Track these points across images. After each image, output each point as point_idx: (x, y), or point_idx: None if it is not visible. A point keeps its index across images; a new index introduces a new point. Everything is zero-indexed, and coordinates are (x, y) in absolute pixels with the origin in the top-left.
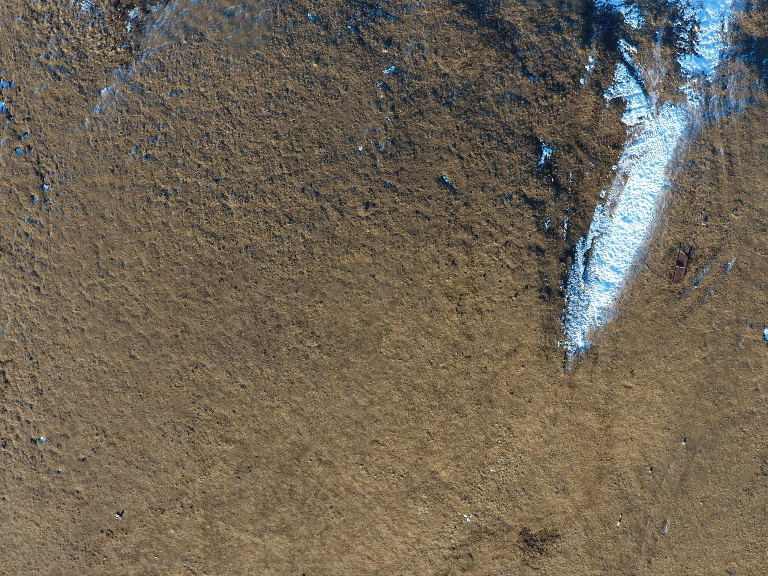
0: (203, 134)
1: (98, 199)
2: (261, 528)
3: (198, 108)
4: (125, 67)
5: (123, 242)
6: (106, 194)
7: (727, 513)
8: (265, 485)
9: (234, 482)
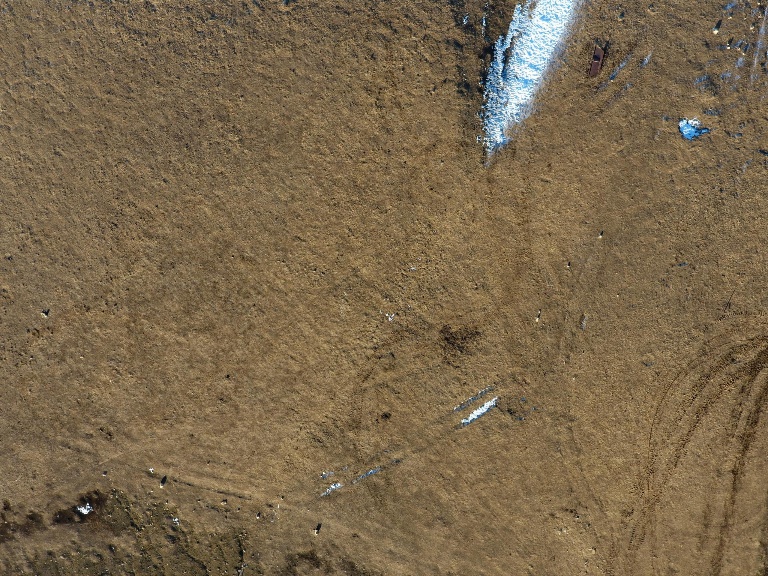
0: None
1: None
2: (185, 326)
3: None
4: None
5: (48, 41)
6: None
7: (643, 304)
8: (188, 282)
9: (157, 278)
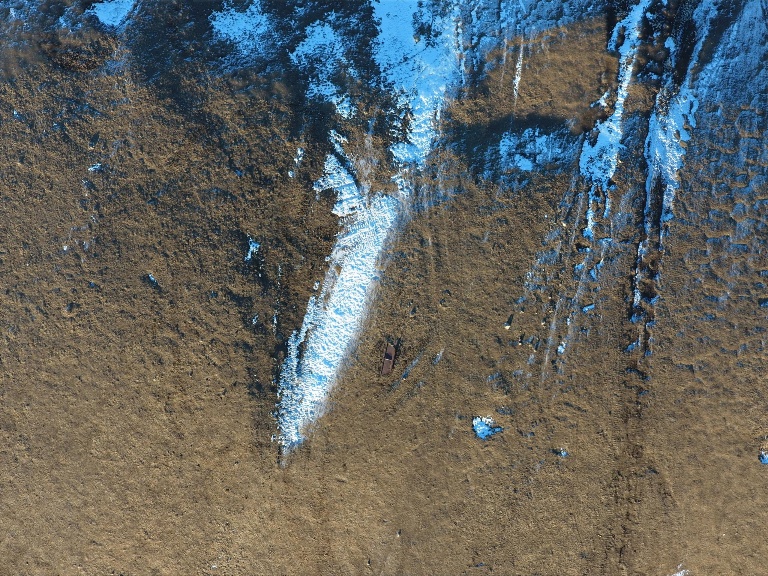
0: None
1: None
2: None
3: None
4: None
5: None
6: None
7: None
8: None
9: None
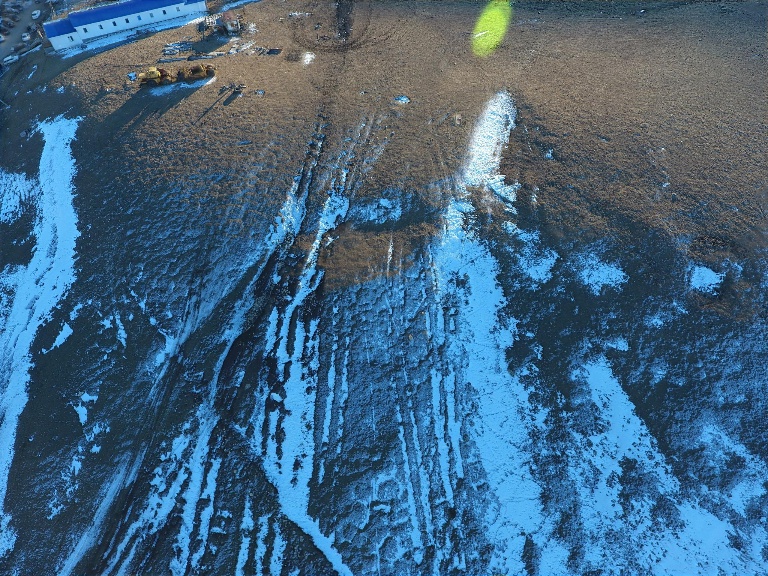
0: (764, 151)
1: None
2: None
3: None
4: None
5: None
6: None
7: None
8: None
9: (653, 49)
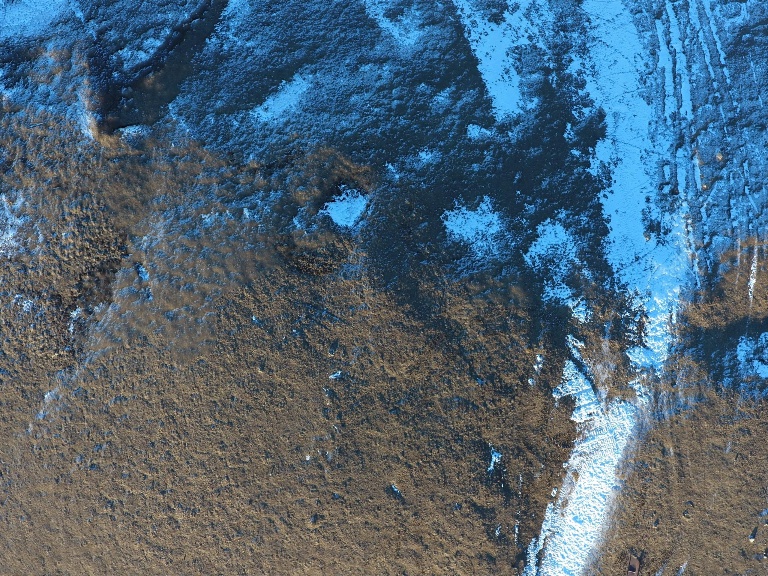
0: (148, 444)
1: (43, 510)
2: None
3: (143, 417)
4: (68, 371)
5: (69, 555)
6: (51, 505)
7: None
8: None
9: None
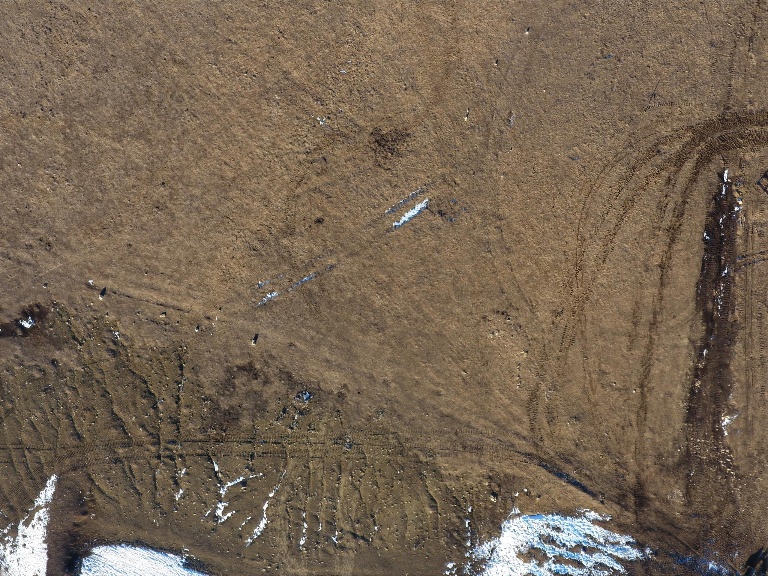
0: None
1: None
2: (119, 132)
3: None
4: None
5: None
6: None
7: (569, 98)
8: (121, 86)
9: (91, 82)
